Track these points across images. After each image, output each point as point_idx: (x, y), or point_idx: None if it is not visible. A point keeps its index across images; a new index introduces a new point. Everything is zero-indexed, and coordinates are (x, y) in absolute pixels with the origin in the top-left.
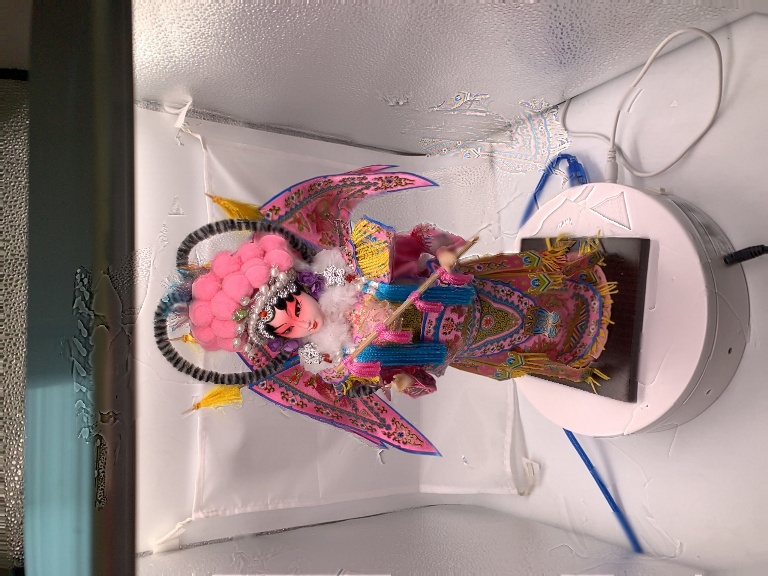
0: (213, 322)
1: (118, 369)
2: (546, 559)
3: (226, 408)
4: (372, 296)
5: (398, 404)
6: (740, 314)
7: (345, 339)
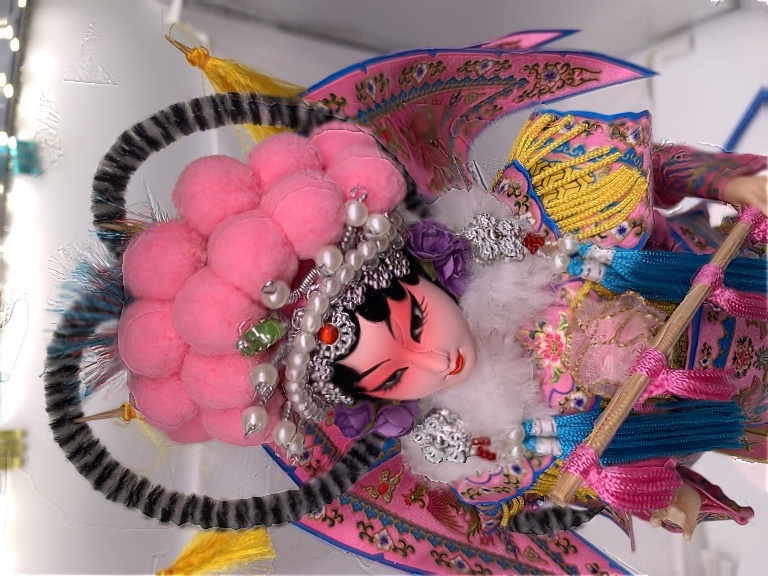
0: (185, 363)
1: None
2: None
3: (237, 571)
4: (592, 284)
5: (595, 530)
6: None
7: (528, 397)
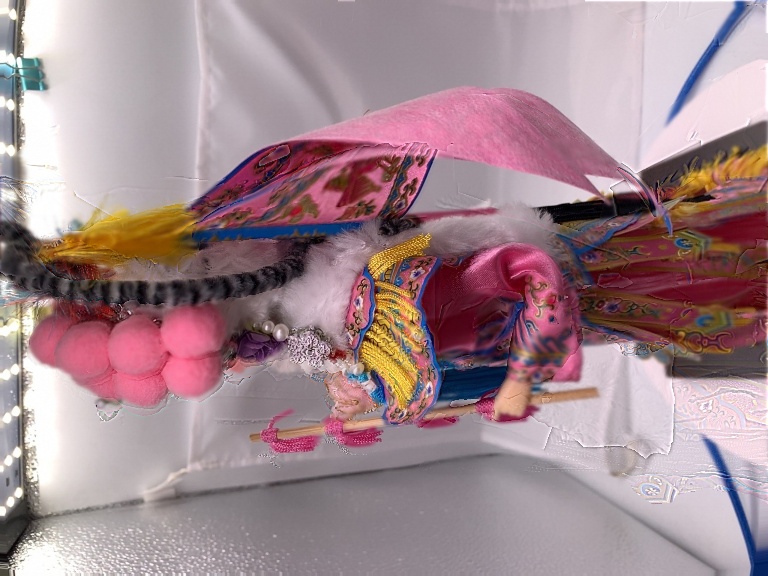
0: None
1: None
2: None
3: None
4: None
5: None
6: None
7: None
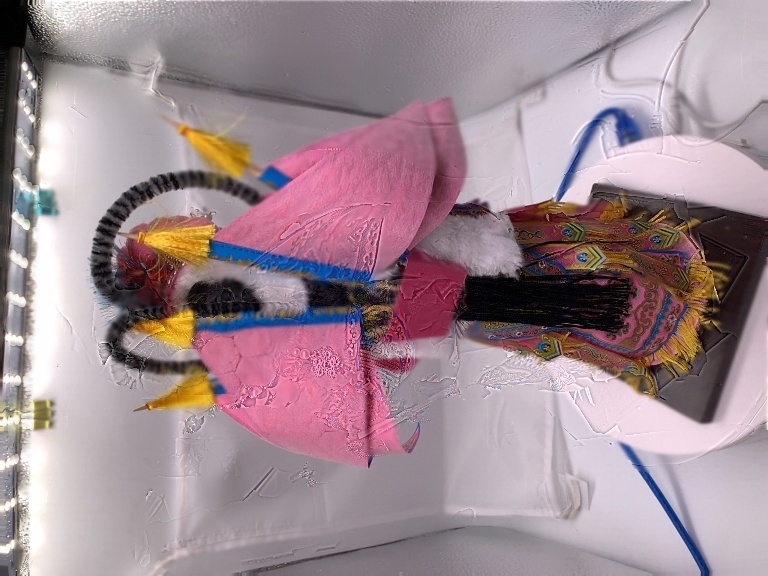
0: None
1: (62, 318)
2: (448, 521)
3: None
4: None
5: None
6: (760, 421)
7: None
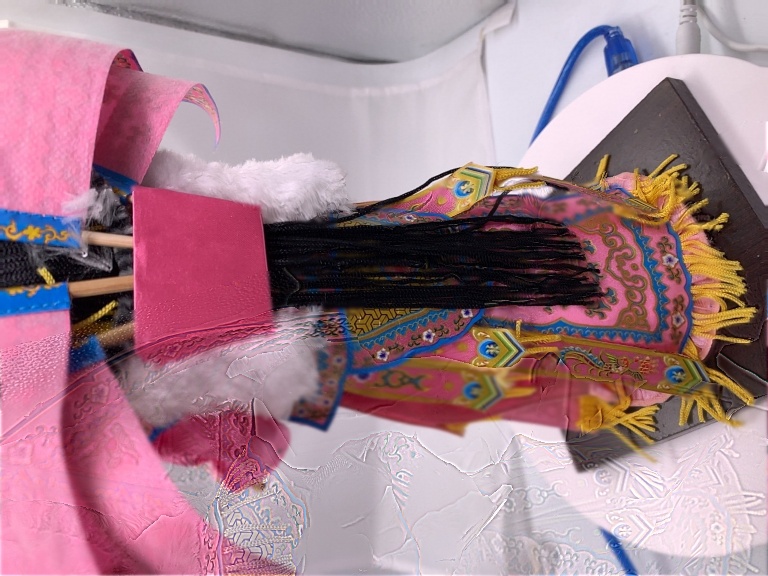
0: None
1: None
2: None
3: None
4: None
5: None
6: None
7: None
